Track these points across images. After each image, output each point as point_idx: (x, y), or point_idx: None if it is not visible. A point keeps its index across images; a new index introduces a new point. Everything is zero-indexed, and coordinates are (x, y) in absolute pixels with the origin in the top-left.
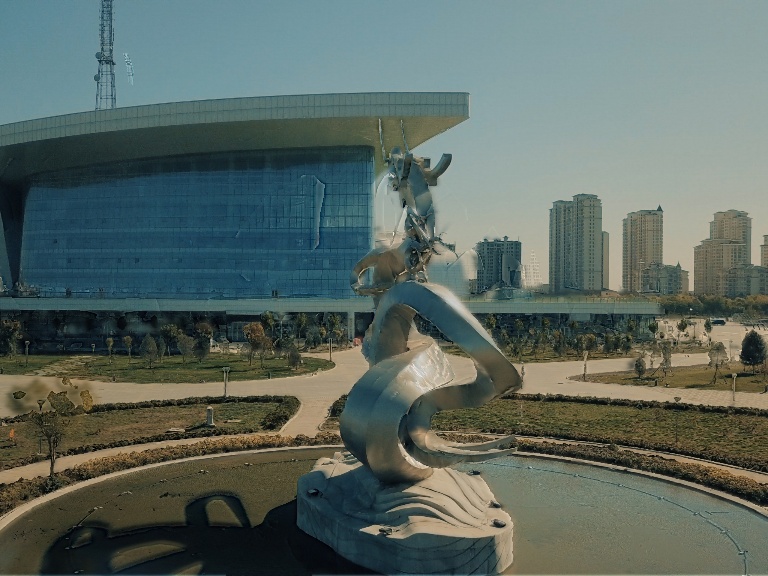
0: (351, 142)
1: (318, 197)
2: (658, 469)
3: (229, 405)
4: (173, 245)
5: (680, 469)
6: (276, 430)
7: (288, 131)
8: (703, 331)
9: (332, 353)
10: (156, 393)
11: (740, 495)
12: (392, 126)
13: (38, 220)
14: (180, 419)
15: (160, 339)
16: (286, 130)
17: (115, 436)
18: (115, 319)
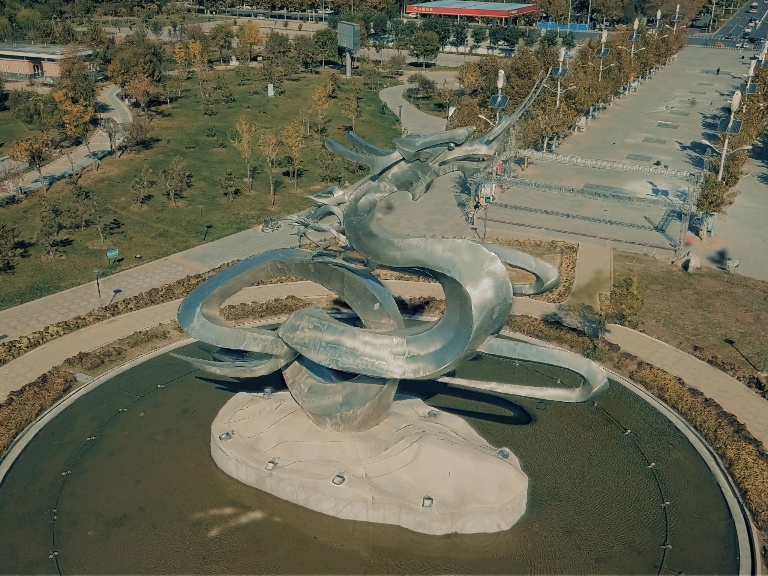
0: None
1: None
2: None
3: None
4: None
5: None
6: None
7: None
8: None
9: None
10: None
11: None
12: None
13: None
14: None
15: None
16: None
17: None
18: None
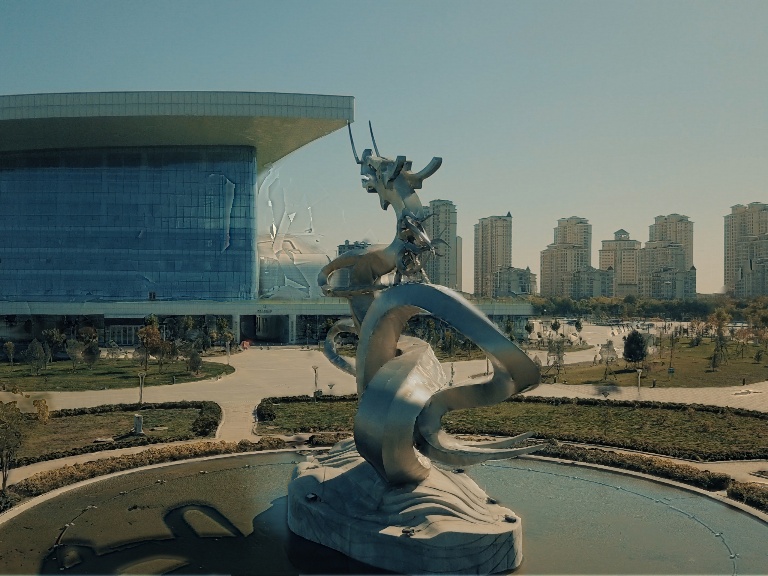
0: (233, 142)
1: (228, 197)
2: (604, 461)
3: (147, 412)
4: (40, 245)
5: (625, 460)
6: (210, 436)
7: (168, 128)
8: (571, 331)
9: (224, 357)
10: (59, 402)
11: (688, 482)
12: (277, 127)
13: None
14: (101, 428)
15: (45, 344)
16: (166, 127)
17: (39, 448)
18: None
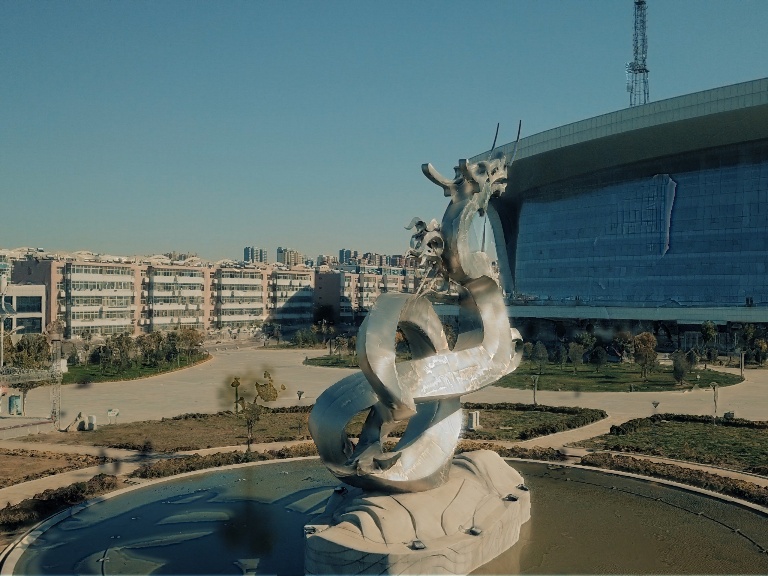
0: None
1: (669, 197)
2: None
3: (530, 413)
4: None
5: None
6: (525, 440)
7: (757, 120)
8: None
9: None
10: (496, 397)
11: None
12: None
13: (528, 233)
14: (463, 421)
15: (561, 346)
16: (754, 119)
17: None
18: (578, 326)
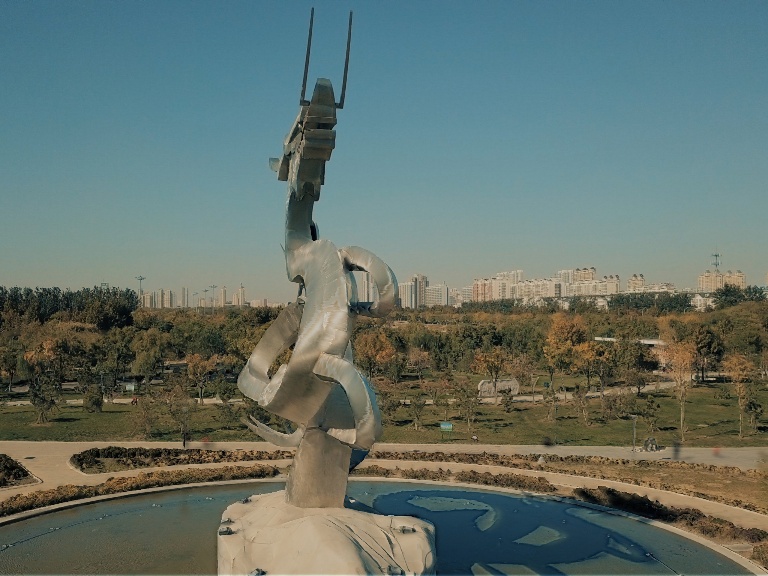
0: None
1: None
2: None
3: None
4: None
5: None
6: None
7: None
8: None
9: None
10: None
11: None
12: None
13: None
14: None
15: None
16: None
17: None
18: None
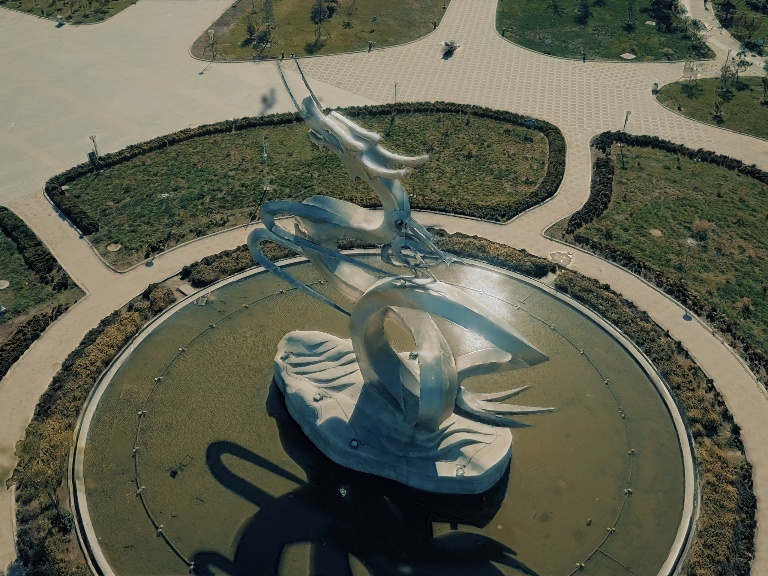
0: None
1: None
2: (447, 250)
3: None
4: None
5: (464, 248)
6: (74, 289)
7: None
8: None
9: None
10: None
11: (520, 271)
12: None
13: None
14: None
15: None
16: None
17: None
18: None
